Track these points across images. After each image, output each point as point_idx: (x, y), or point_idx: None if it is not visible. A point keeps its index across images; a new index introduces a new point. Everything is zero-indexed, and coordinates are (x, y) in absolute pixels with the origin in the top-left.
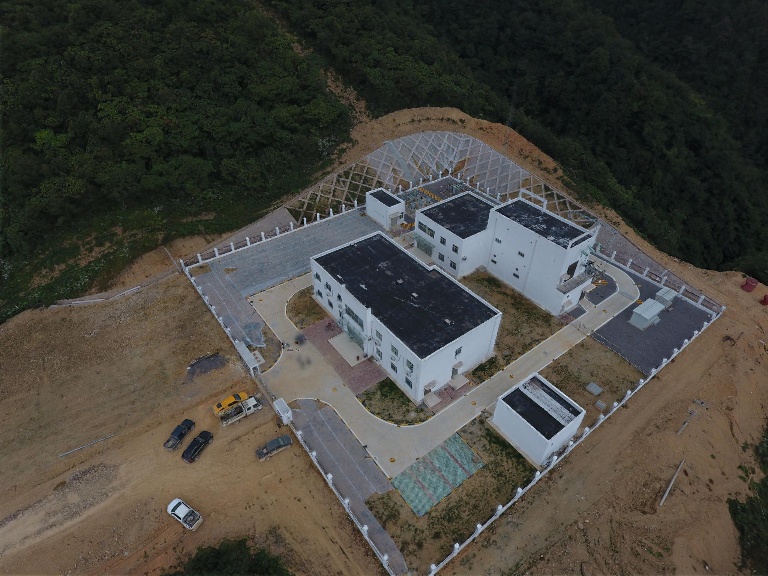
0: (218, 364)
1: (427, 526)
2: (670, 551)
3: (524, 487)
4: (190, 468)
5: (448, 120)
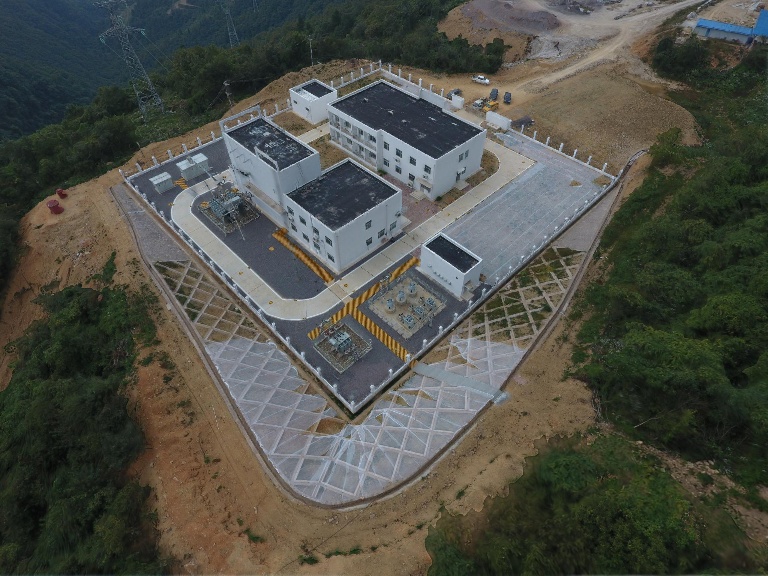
0: None
1: None
2: (270, 86)
3: None
4: None
5: (356, 551)
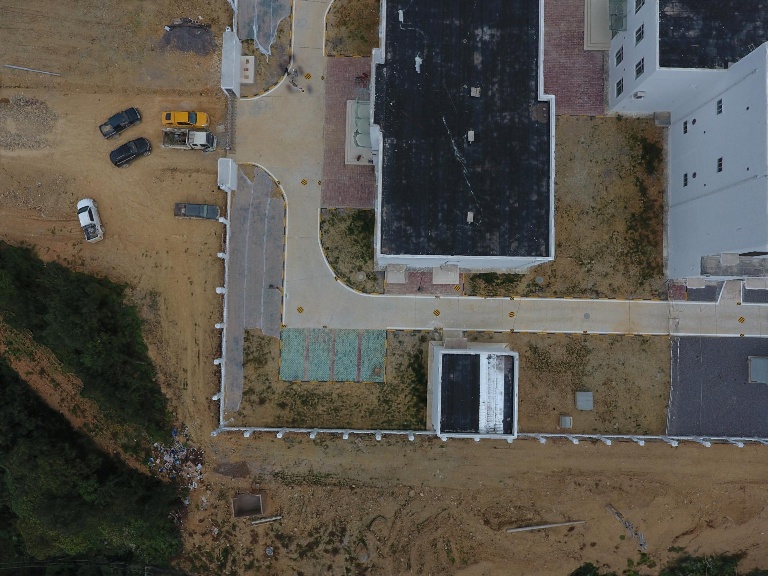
0: (199, 47)
1: (281, 392)
2: (464, 566)
3: (397, 428)
4: (117, 171)
5: None
